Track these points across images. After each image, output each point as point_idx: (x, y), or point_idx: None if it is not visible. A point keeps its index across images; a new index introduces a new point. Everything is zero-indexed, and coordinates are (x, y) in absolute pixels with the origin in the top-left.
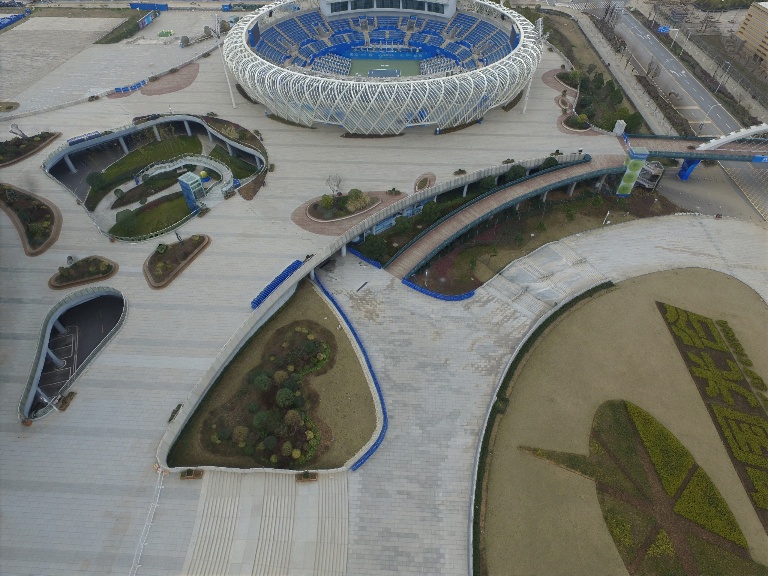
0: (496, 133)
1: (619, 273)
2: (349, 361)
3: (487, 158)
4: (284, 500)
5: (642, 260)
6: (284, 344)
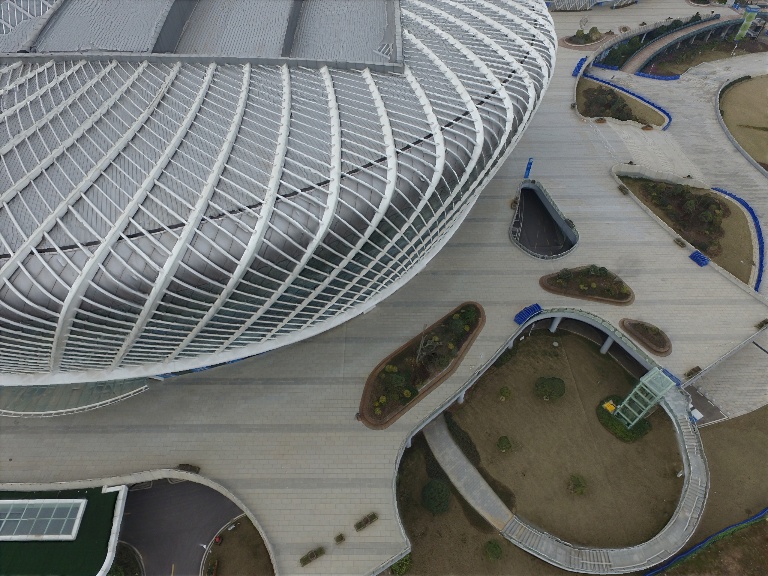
0: (651, 8)
1: (751, 74)
2: (632, 100)
3: (654, 18)
4: (644, 133)
5: (762, 69)
6: (595, 93)
